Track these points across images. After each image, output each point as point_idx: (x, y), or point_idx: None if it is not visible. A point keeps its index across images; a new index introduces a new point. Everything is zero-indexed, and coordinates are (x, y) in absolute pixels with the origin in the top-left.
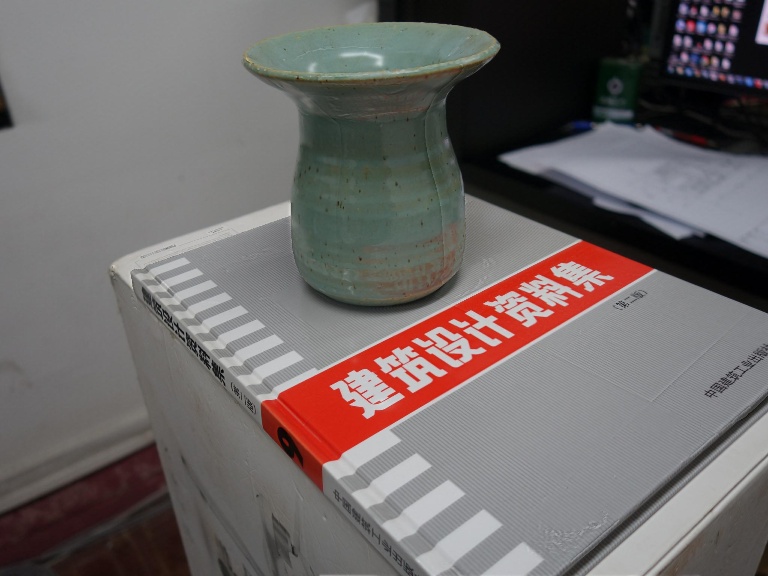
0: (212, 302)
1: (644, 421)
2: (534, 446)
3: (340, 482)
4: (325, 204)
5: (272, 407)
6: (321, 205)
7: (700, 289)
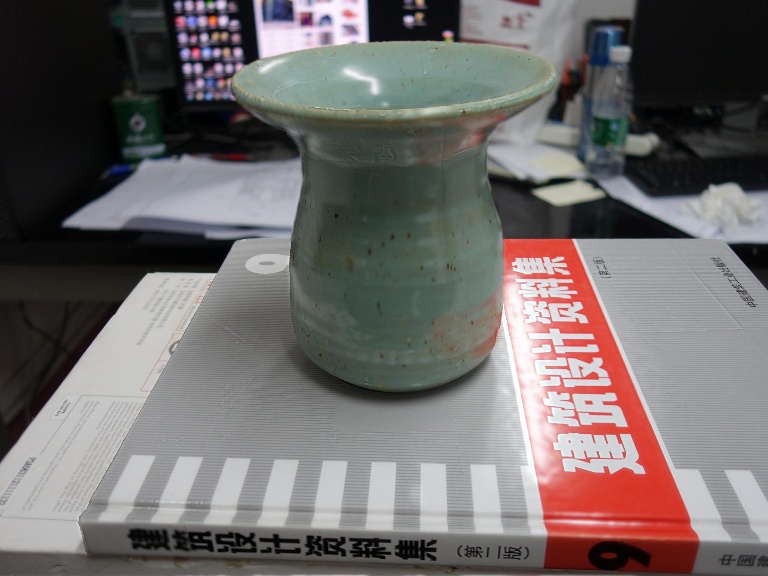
0: (283, 480)
1: (764, 344)
2: (760, 405)
3: (737, 541)
4: (430, 273)
5: (563, 531)
6: (424, 277)
7: (620, 240)
